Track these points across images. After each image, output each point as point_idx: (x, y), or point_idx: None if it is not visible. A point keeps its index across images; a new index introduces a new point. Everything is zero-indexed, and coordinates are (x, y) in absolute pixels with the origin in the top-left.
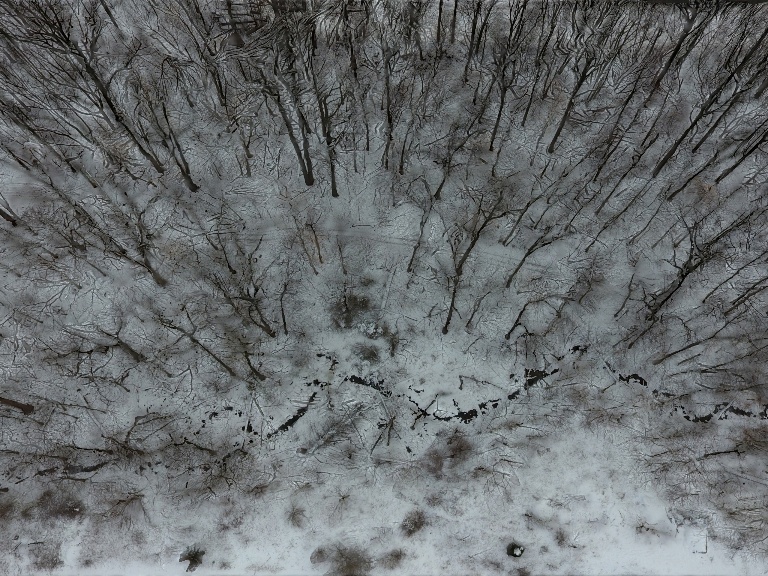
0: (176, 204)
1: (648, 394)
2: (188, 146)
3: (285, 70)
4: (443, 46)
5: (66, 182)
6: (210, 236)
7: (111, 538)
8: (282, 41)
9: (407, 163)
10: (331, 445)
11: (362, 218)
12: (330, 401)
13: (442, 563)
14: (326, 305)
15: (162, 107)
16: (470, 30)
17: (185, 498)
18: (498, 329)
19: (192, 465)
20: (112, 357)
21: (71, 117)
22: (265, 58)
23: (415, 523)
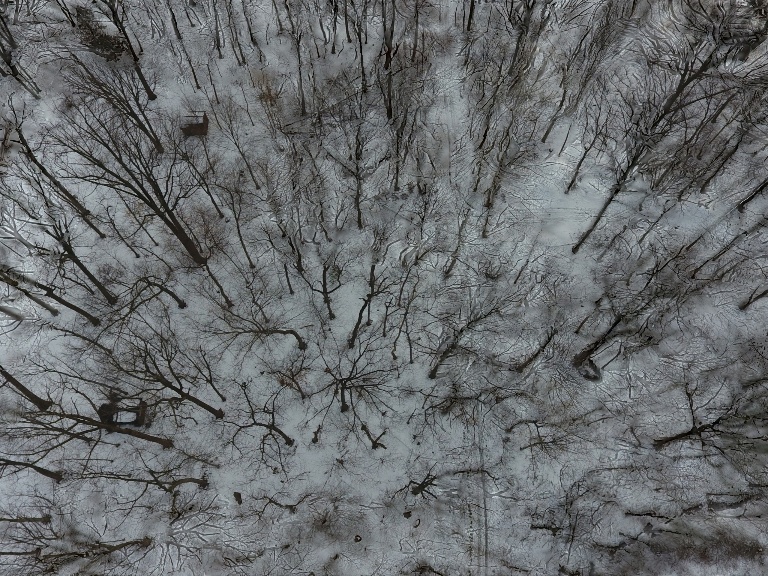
0: (728, 226)
1: None
2: (724, 165)
3: None
4: None
5: None
6: None
7: None
8: None
9: None
10: None
11: None
12: None
13: None
14: None
15: None
16: None
17: None
18: None
19: None
20: (722, 387)
21: None
22: None
23: None
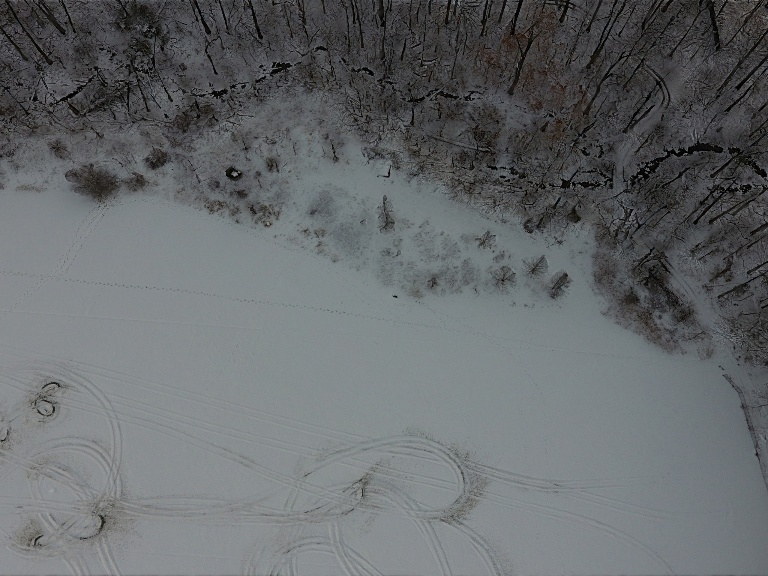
0: None
1: (373, 81)
2: None
3: None
4: None
5: None
6: None
7: None
8: None
9: None
10: (101, 110)
11: None
12: None
13: (178, 189)
14: (110, 11)
15: None
16: None
17: None
18: (253, 30)
19: None
20: None
21: None
22: None
23: (158, 159)
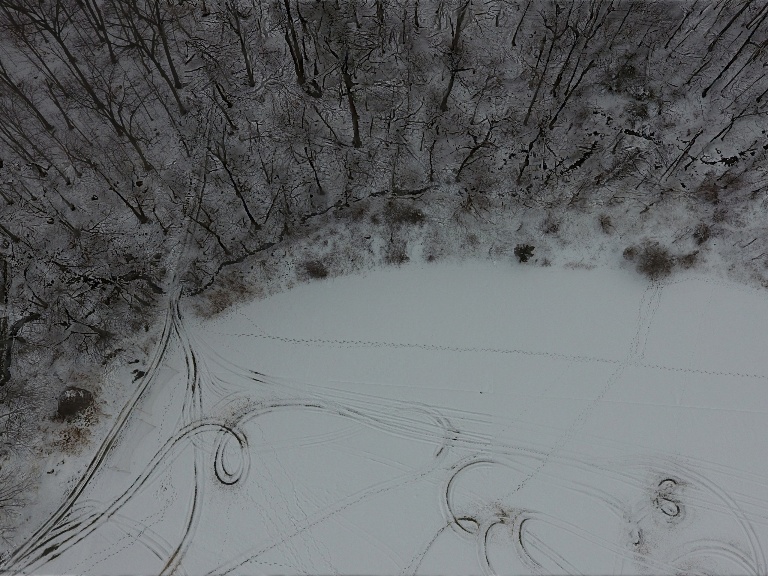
0: None
1: None
2: None
3: None
4: None
5: None
6: (503, 6)
7: (449, 239)
8: None
9: None
10: (618, 179)
11: (621, 3)
12: None
13: (728, 266)
14: (598, 72)
15: None
16: None
17: (507, 211)
18: (750, 94)
19: (502, 192)
20: (422, 106)
21: None
22: None
23: (704, 234)
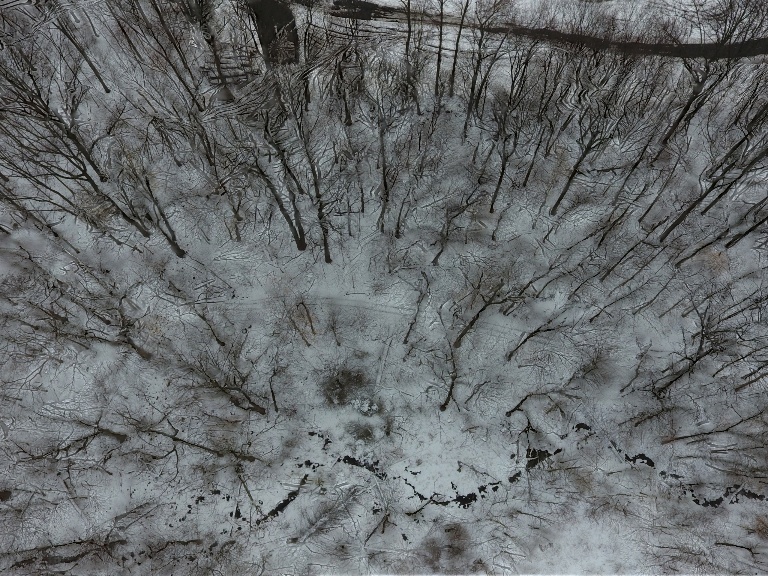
0: (162, 271)
1: (655, 476)
2: (175, 208)
3: (277, 127)
4: (441, 100)
5: (48, 247)
6: (197, 309)
7: None
8: (273, 98)
9: (404, 226)
10: (323, 533)
11: (356, 286)
12: (322, 488)
13: None
14: (318, 380)
15: (145, 181)
16: (469, 86)
17: None
18: (498, 406)
19: (177, 555)
20: (94, 438)
21: (52, 182)
22: (256, 115)
23: None
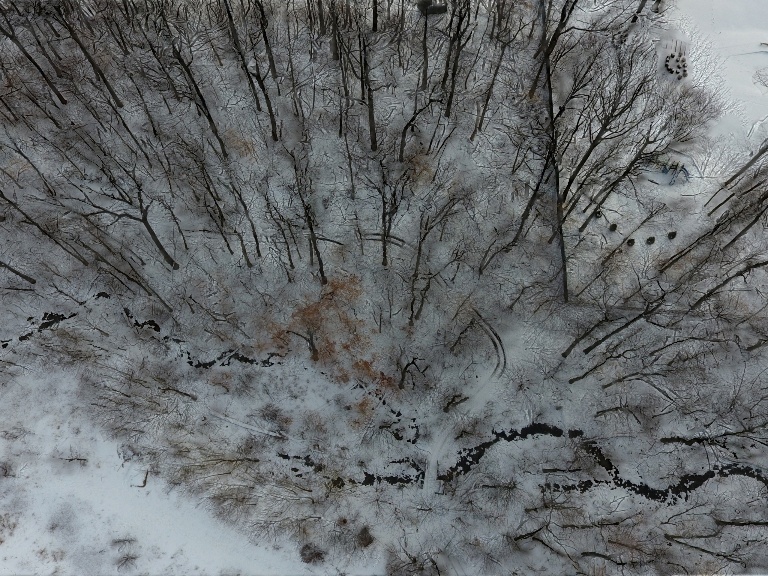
0: None
1: None
2: None
3: None
4: (41, 2)
5: None
6: None
7: None
8: None
9: None
10: None
11: None
12: None
13: None
14: None
15: None
16: None
17: None
18: (25, 273)
19: None
20: None
21: None
22: None
23: None
